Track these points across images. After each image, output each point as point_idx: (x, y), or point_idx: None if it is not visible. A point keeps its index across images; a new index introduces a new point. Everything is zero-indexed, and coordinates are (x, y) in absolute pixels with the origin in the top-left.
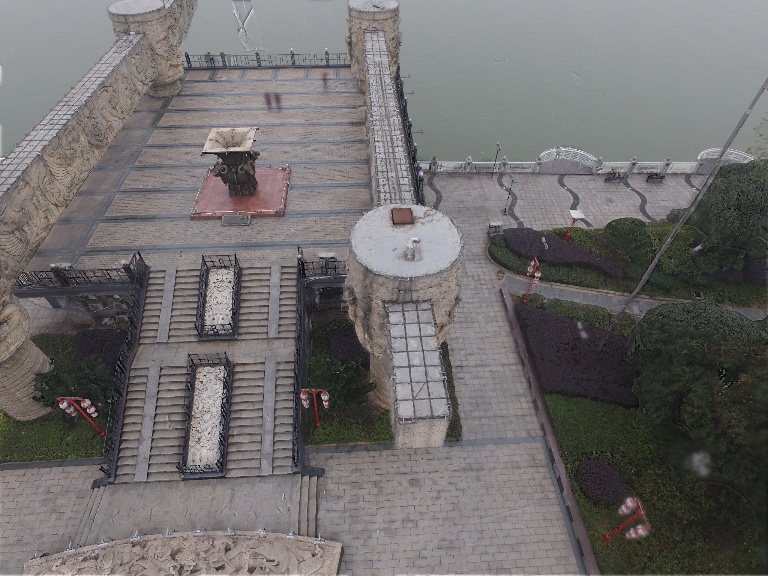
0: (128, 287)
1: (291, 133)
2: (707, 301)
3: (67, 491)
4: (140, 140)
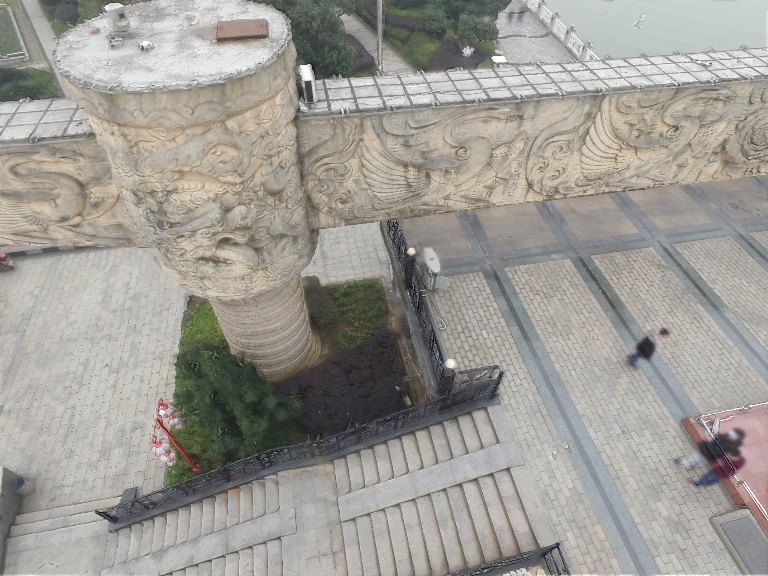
0: (432, 385)
1: None
2: None
3: (129, 455)
4: None
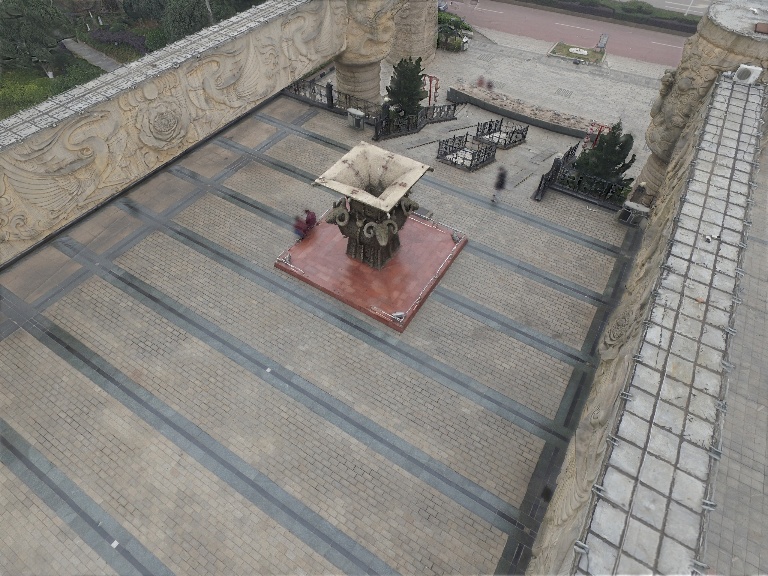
0: None
1: (179, 370)
2: (175, 0)
3: None
4: (524, 575)
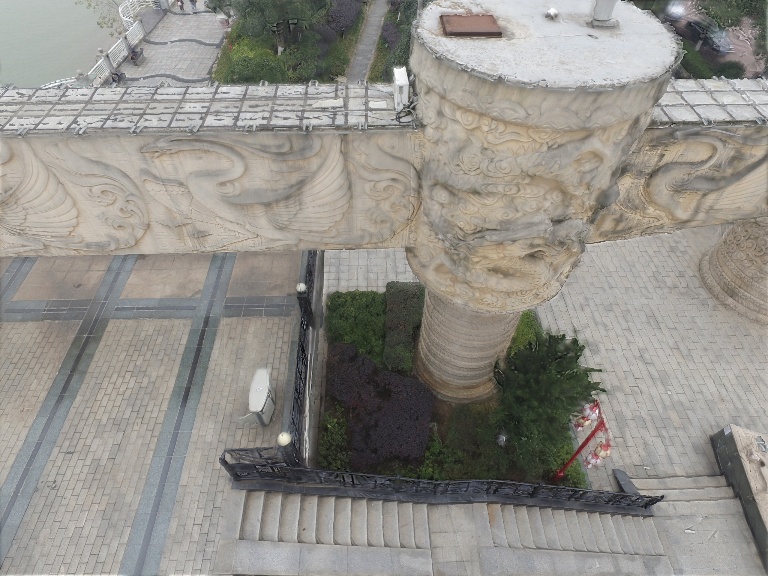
0: None
1: None
2: None
3: None
4: None
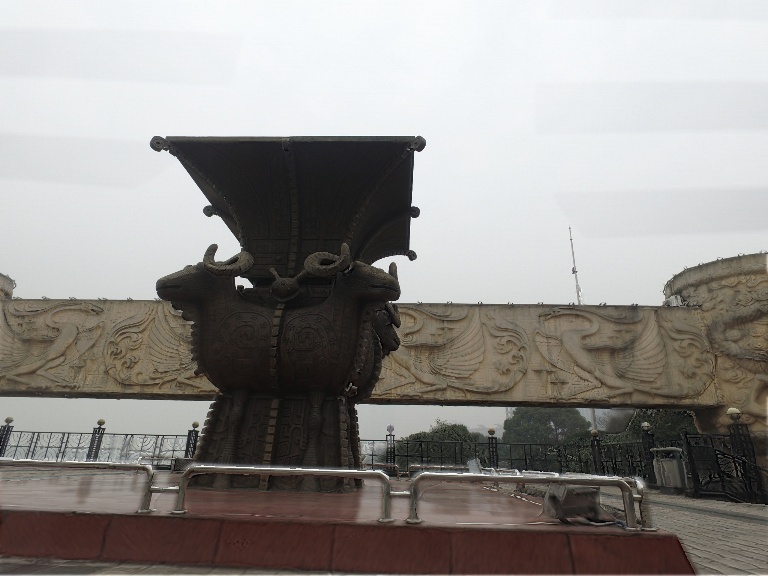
0: None
1: None
2: None
3: None
4: None
